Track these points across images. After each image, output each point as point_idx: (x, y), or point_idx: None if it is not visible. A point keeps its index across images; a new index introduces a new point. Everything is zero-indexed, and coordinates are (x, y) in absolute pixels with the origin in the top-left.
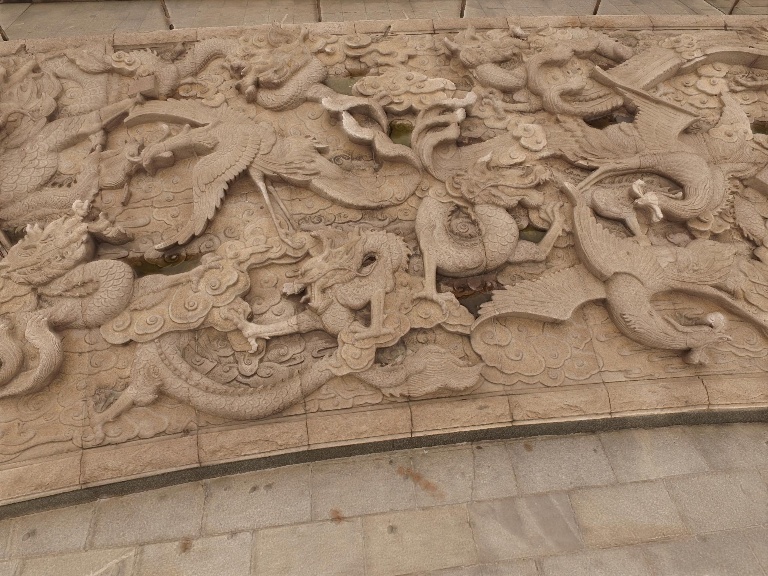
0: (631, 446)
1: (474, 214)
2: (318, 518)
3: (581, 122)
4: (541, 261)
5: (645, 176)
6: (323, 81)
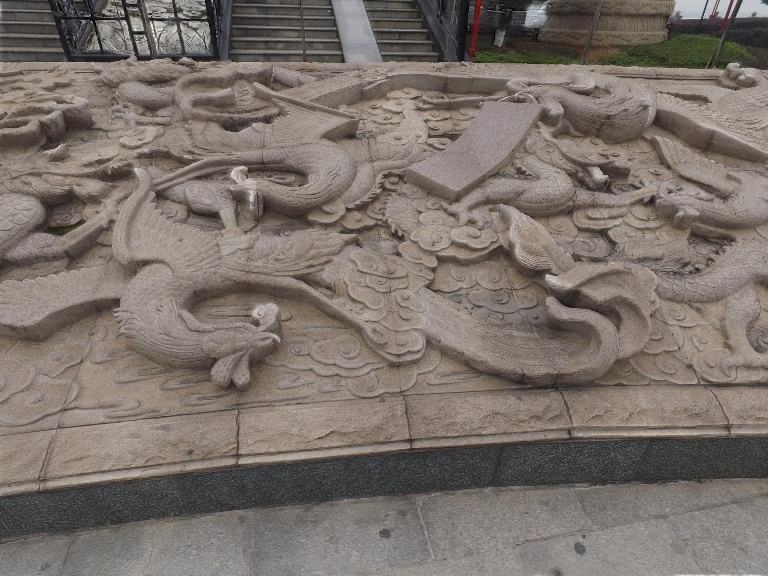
0: (121, 556)
1: None
2: None
3: (213, 125)
4: (55, 257)
5: (278, 175)
6: None
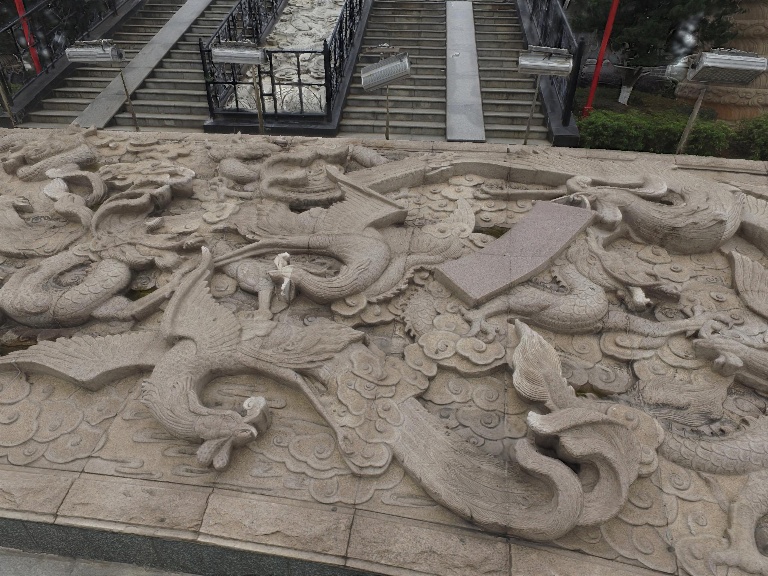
0: None
1: (95, 268)
2: None
3: (280, 206)
4: (125, 319)
5: (321, 259)
6: (80, 163)
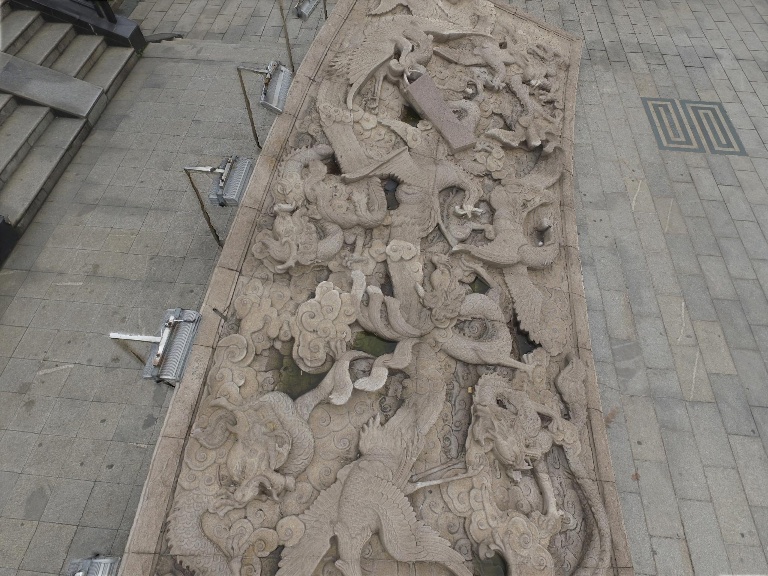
0: None
1: (465, 317)
2: (637, 489)
3: (394, 213)
4: None
5: (439, 200)
6: None
